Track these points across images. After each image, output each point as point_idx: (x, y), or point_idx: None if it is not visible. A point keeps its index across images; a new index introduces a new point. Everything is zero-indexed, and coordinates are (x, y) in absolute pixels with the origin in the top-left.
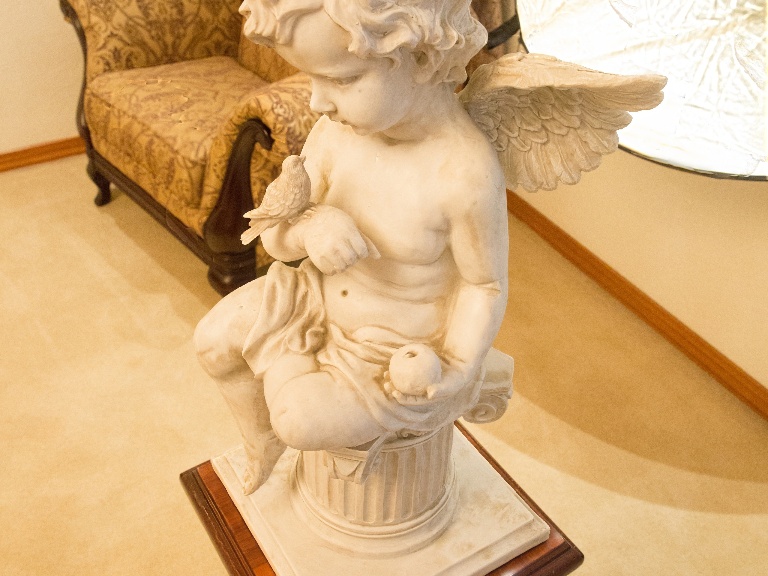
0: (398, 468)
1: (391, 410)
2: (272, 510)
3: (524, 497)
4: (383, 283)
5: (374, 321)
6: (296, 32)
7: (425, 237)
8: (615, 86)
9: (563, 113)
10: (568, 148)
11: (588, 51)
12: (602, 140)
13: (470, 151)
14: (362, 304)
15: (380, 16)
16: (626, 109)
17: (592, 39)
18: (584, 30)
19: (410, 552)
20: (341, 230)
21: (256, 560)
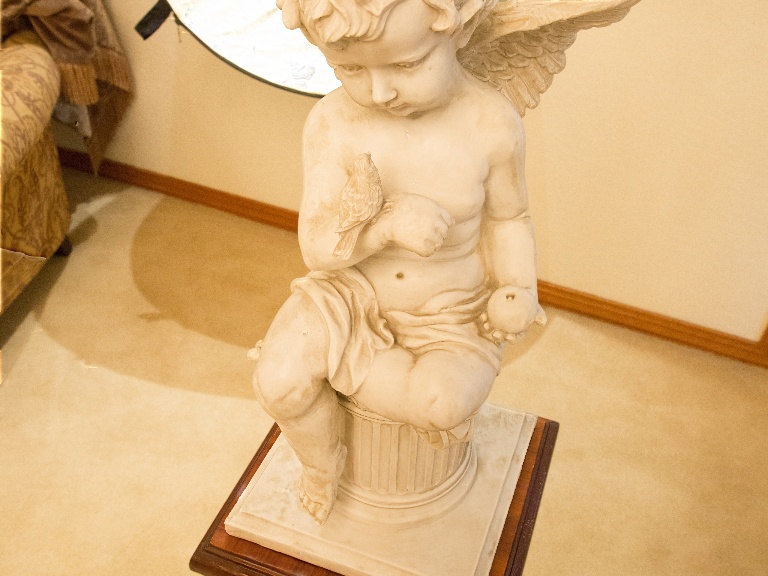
0: None
1: (500, 356)
2: (330, 530)
3: None
4: (437, 250)
5: (441, 288)
6: (388, 24)
7: (479, 190)
8: (616, 6)
9: (528, 46)
10: (530, 77)
11: (246, 16)
12: (558, 61)
13: (496, 99)
14: (426, 278)
15: None
16: (601, 25)
17: (244, 4)
18: None
19: (468, 491)
20: (432, 208)
21: None
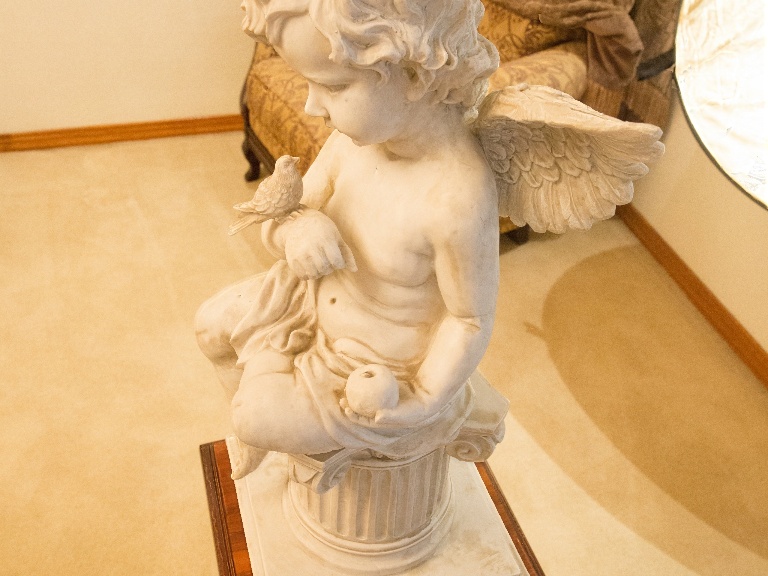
0: (371, 487)
1: (346, 426)
2: (262, 500)
3: (523, 549)
4: (367, 298)
5: (353, 334)
6: (284, 33)
7: (405, 258)
8: (602, 131)
9: (575, 153)
10: (579, 191)
11: (746, 96)
12: (614, 188)
13: (460, 178)
14: (344, 315)
15: (360, 27)
16: (625, 158)
17: (753, 84)
18: (746, 73)
19: (380, 575)
20: (317, 237)
21: (238, 544)
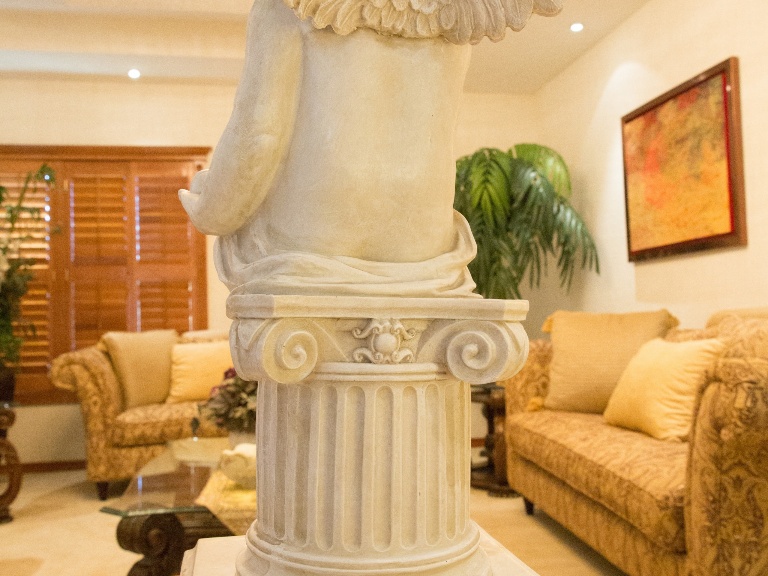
0: None
1: None
2: None
3: None
4: None
5: None
6: None
7: None
8: None
9: None
10: None
11: None
12: None
13: None
14: None
15: None
16: None
17: None
18: None
19: None
20: None
21: None
